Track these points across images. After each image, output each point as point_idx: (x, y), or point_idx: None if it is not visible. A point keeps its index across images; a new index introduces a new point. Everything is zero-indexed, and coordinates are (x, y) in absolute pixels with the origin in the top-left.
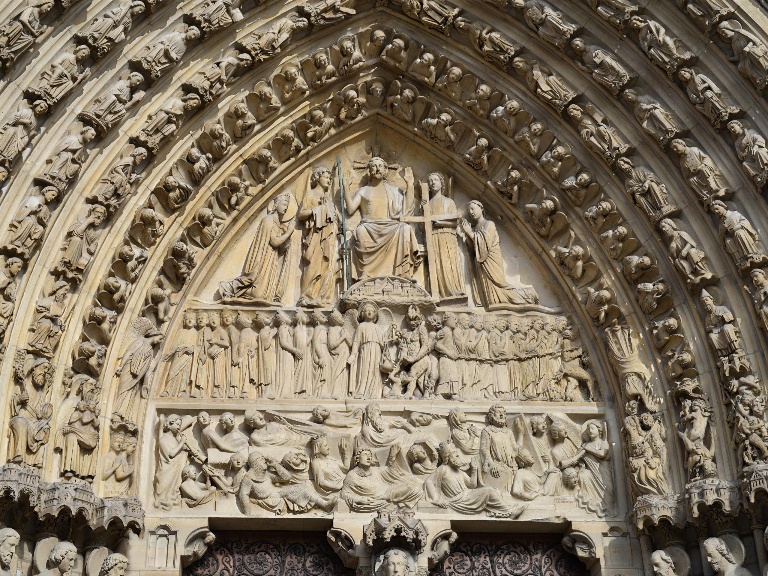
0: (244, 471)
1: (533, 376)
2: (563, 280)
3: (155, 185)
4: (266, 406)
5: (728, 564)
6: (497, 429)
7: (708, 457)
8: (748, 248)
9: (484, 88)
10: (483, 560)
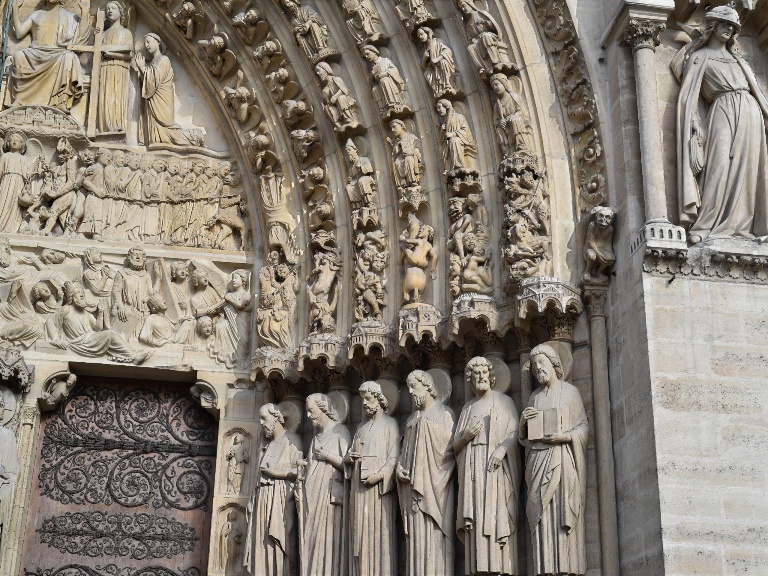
0: None
1: (184, 220)
2: (231, 123)
3: None
4: None
5: (328, 420)
6: (132, 272)
7: (327, 312)
8: (390, 97)
9: None
10: (108, 405)
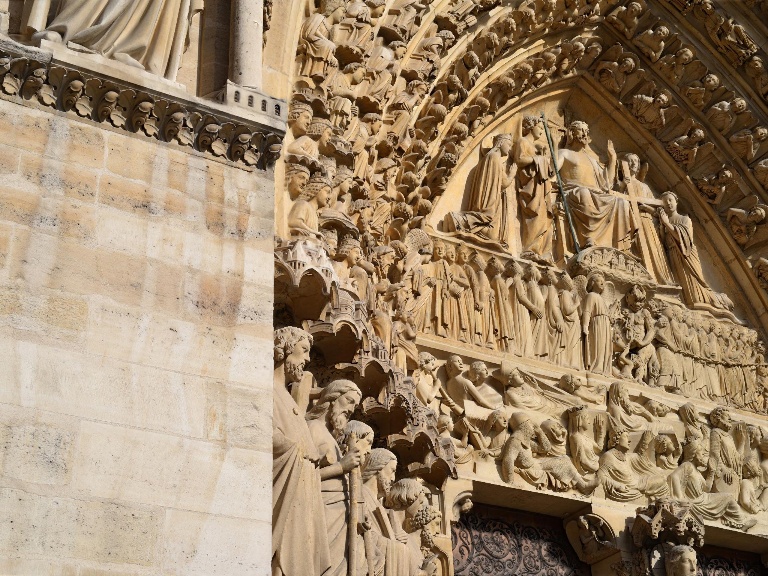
0: (507, 432)
1: None
2: (756, 293)
3: (437, 80)
4: (513, 363)
5: None
6: (725, 433)
7: None
8: None
9: (716, 78)
10: (697, 572)
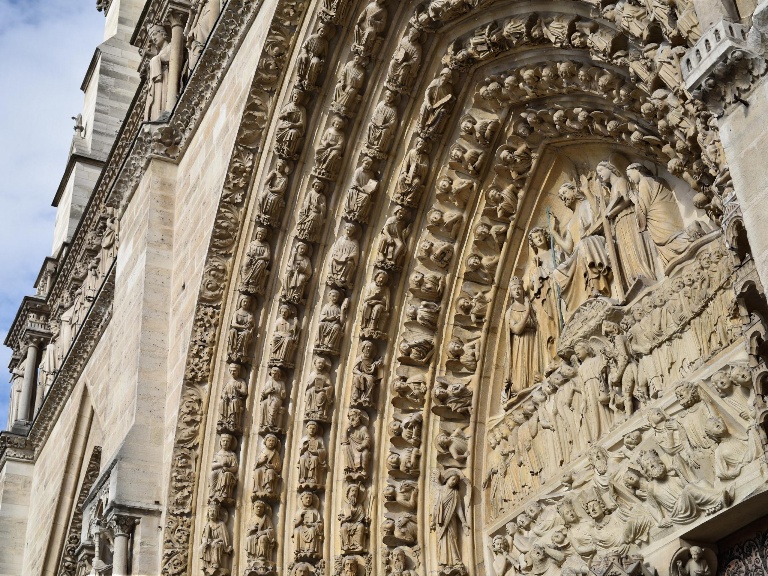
0: None
1: None
2: None
3: None
4: (543, 493)
5: None
6: (685, 412)
7: None
8: (669, 85)
9: (543, 73)
10: (754, 559)
